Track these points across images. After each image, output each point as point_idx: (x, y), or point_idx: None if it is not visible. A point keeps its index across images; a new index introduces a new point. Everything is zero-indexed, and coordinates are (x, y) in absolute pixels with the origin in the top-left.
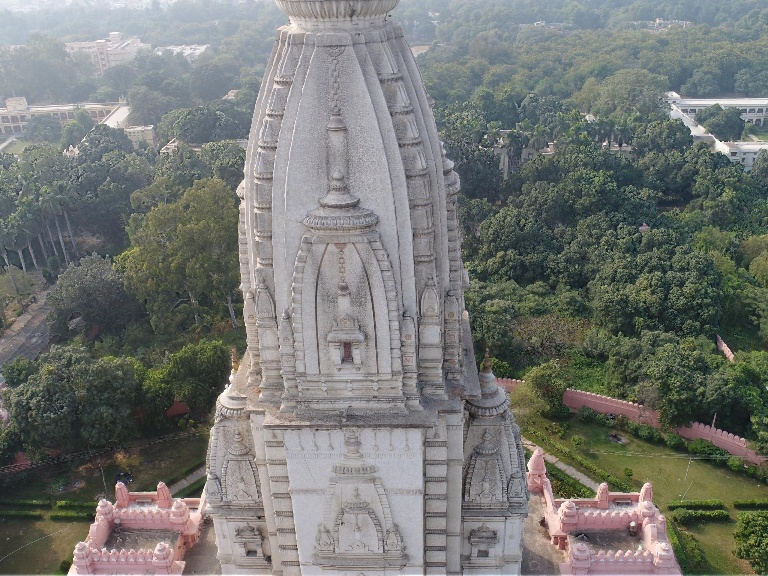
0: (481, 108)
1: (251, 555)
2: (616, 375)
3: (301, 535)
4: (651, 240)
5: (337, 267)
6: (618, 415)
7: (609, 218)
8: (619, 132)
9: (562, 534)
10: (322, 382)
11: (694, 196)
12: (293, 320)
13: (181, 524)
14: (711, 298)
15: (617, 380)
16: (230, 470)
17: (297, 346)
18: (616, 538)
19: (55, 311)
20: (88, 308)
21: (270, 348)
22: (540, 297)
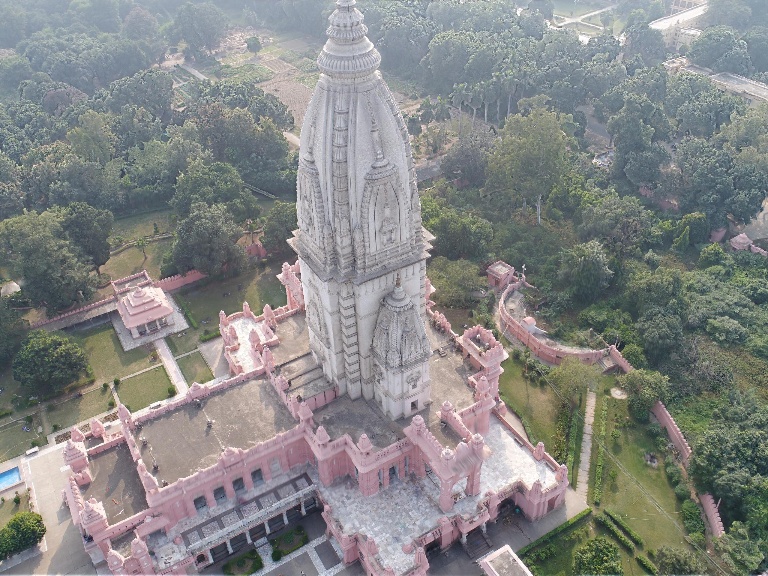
0: None
1: None
2: None
3: None
4: None
5: None
6: (678, 450)
7: None
8: None
9: (439, 416)
10: None
11: None
12: None
13: None
14: None
15: None
16: None
17: None
18: (455, 439)
19: (447, 157)
20: None
21: None
22: None
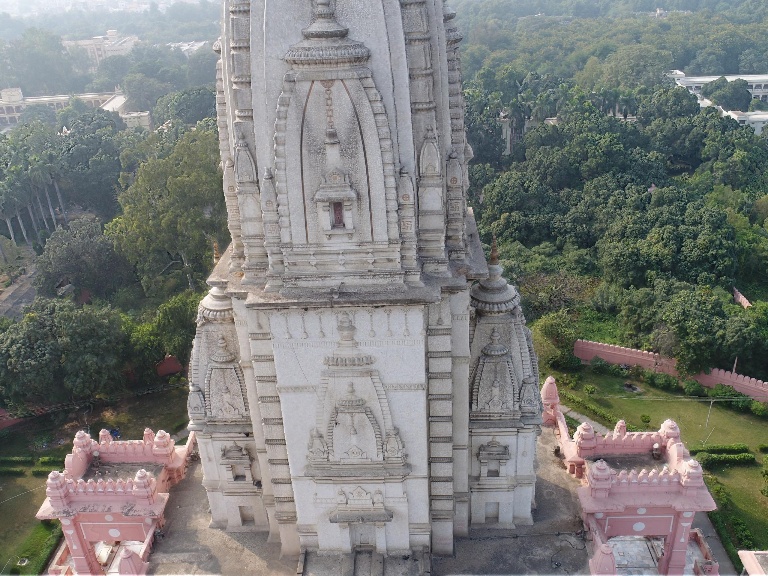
0: (482, 86)
1: (239, 480)
2: (629, 326)
3: (291, 443)
4: (661, 198)
5: (324, 110)
6: (632, 365)
7: (616, 179)
8: (624, 102)
9: (579, 460)
10: (310, 254)
11: (703, 160)
12: (276, 178)
13: (165, 456)
14: (726, 249)
15: (630, 331)
16: (214, 380)
17: (281, 210)
18: (638, 462)
19: (42, 274)
20: (77, 272)
21: (252, 219)
22: (547, 258)
